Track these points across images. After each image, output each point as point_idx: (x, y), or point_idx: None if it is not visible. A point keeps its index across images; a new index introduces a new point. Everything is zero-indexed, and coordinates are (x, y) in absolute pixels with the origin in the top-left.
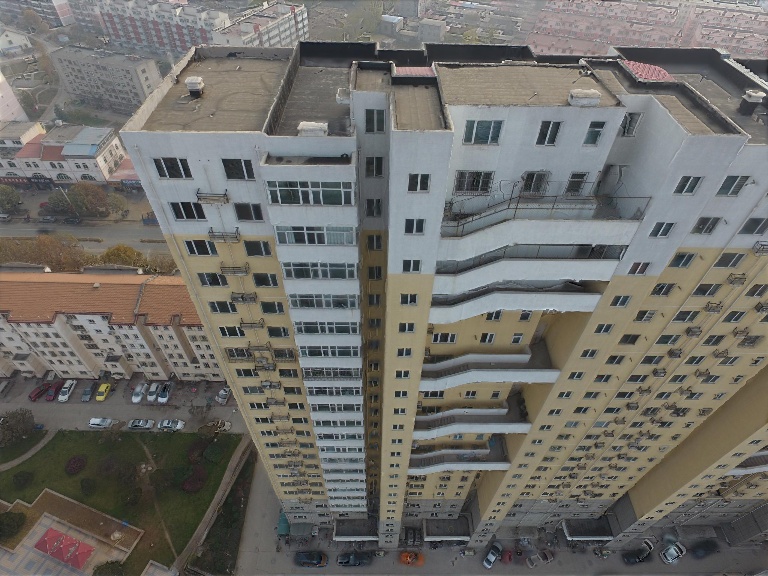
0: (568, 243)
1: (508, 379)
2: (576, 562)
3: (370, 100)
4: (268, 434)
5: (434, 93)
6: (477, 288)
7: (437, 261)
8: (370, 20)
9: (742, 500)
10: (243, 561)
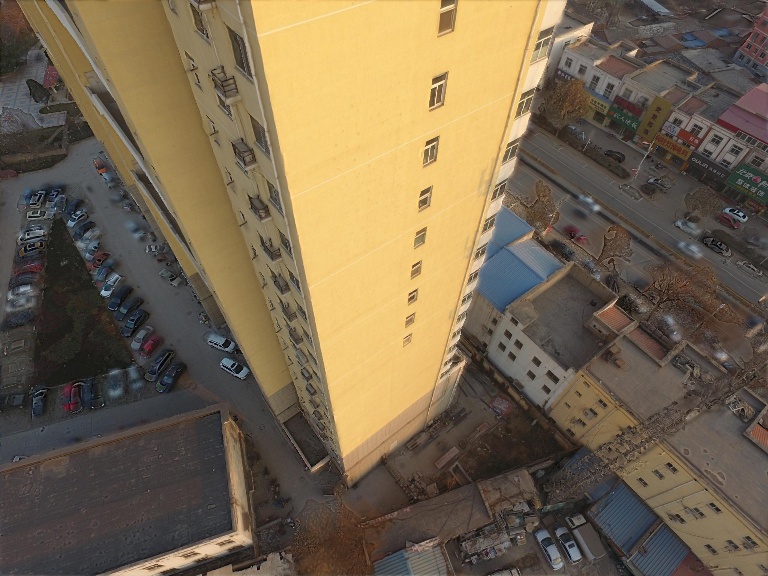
0: None
1: None
2: (184, 303)
3: None
4: None
5: None
6: None
7: None
8: None
9: None
10: (85, 142)
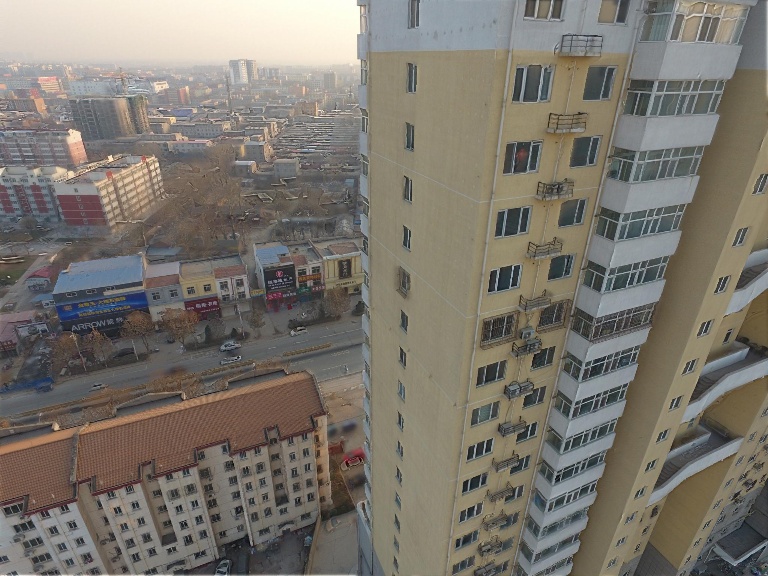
0: None
1: None
2: None
3: None
4: (467, 516)
5: None
6: None
7: None
8: (226, 164)
9: None
10: None
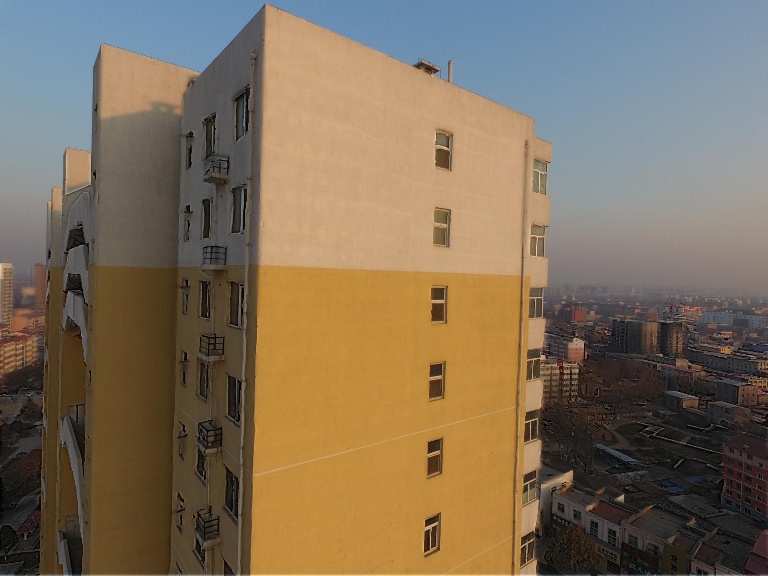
0: None
1: None
2: None
3: None
4: None
5: None
6: None
7: (47, 259)
8: (645, 388)
9: None
10: None
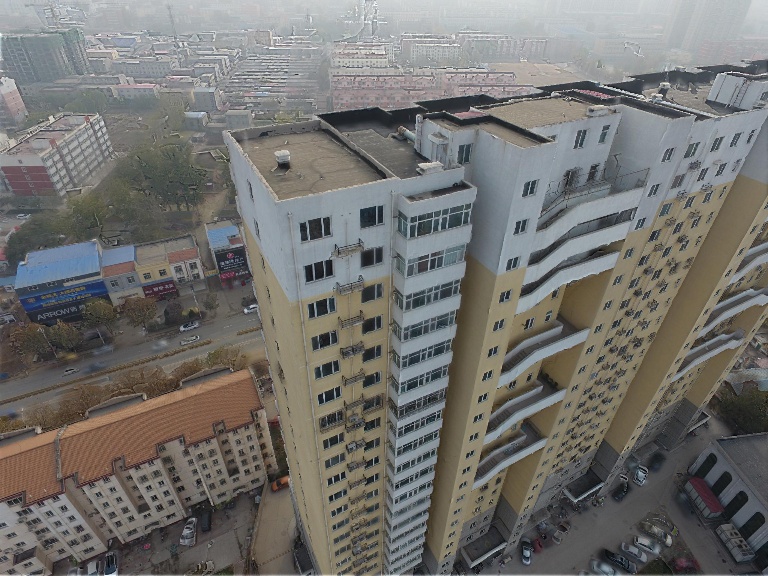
0: (606, 215)
1: (557, 350)
2: (586, 520)
3: (464, 137)
4: (337, 512)
5: (497, 126)
6: (551, 270)
7: (530, 254)
8: (175, 119)
9: (668, 407)
10: None
